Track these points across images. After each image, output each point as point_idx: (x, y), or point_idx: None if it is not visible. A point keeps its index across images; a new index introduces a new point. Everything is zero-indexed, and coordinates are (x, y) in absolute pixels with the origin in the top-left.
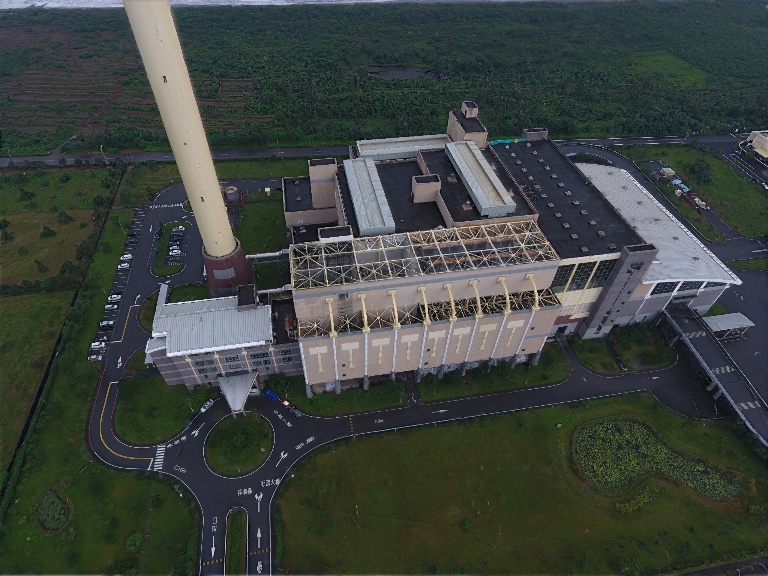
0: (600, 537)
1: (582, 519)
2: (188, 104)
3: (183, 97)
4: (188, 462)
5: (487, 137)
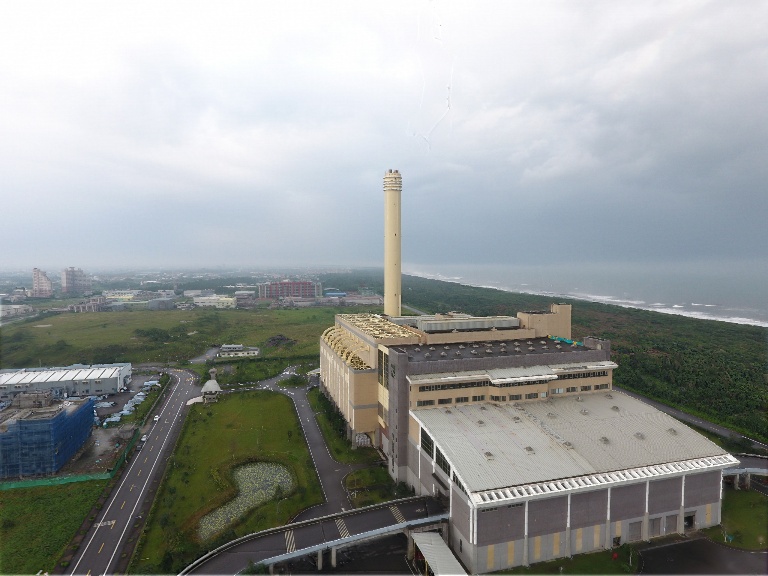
0: (200, 463)
1: (215, 458)
2: (389, 247)
3: (388, 244)
4: None
5: None
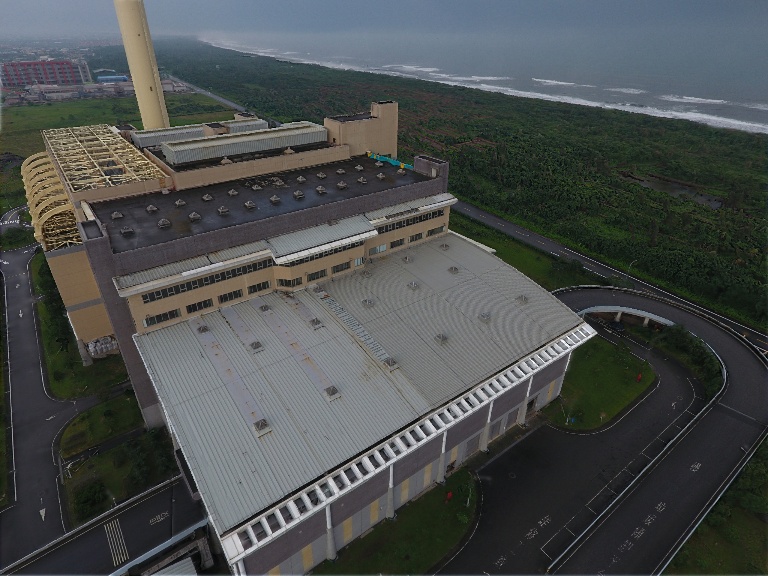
0: None
1: None
2: (121, 2)
3: None
4: (0, 230)
5: (595, 251)
